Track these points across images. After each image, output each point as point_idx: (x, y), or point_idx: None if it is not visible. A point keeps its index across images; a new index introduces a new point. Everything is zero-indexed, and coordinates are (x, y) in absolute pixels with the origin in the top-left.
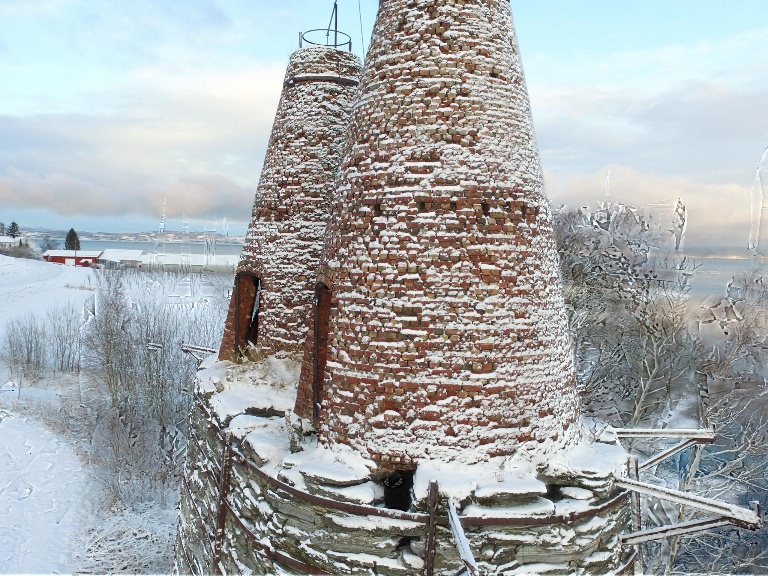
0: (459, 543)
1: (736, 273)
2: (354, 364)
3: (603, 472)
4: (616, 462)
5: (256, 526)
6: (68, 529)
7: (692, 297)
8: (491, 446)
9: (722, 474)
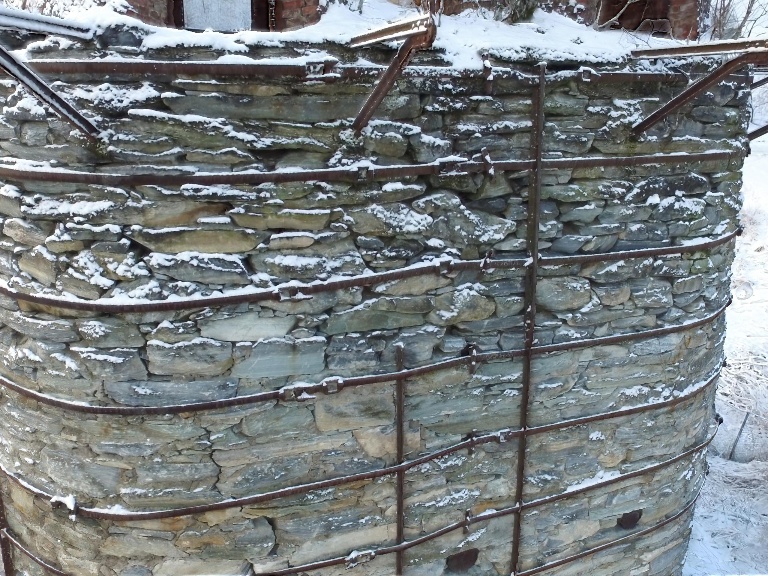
0: None
1: None
2: None
3: None
4: None
5: None
6: (744, 343)
7: None
8: None
9: None
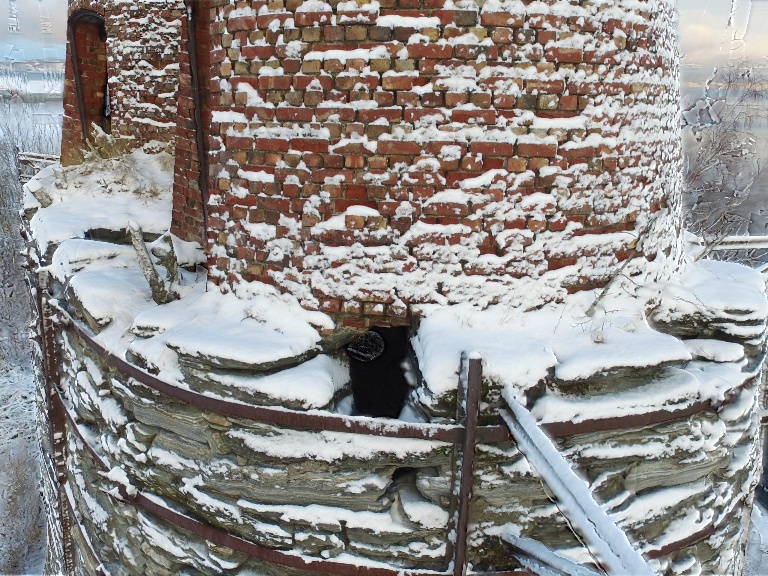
0: (585, 525)
1: (720, 66)
2: (271, 109)
3: (762, 309)
4: (759, 289)
5: (101, 443)
6: None
7: None
8: (569, 271)
9: None
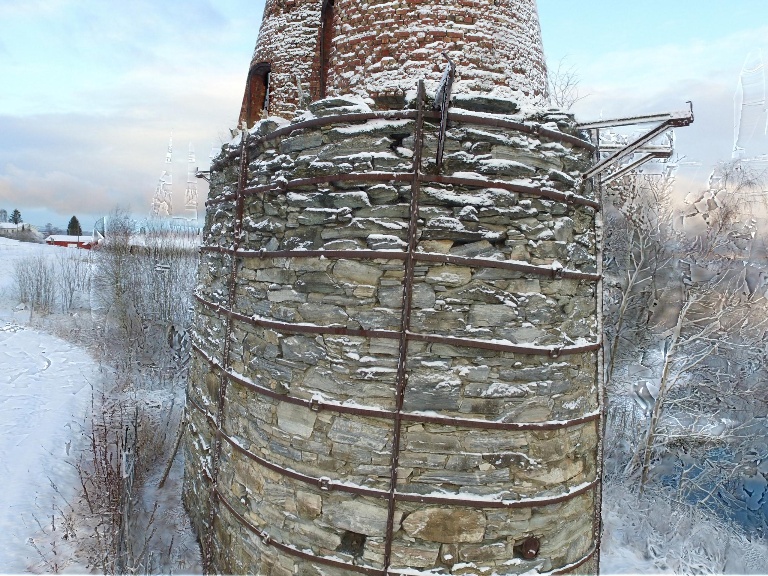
0: None
1: (717, 163)
2: (355, 29)
3: (566, 110)
4: None
5: (271, 177)
6: (84, 397)
7: (676, 189)
8: (471, 82)
9: (701, 337)
